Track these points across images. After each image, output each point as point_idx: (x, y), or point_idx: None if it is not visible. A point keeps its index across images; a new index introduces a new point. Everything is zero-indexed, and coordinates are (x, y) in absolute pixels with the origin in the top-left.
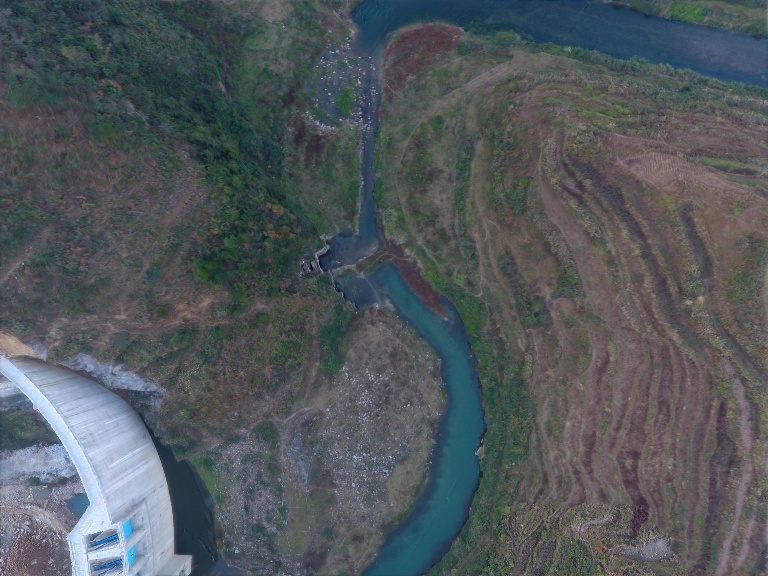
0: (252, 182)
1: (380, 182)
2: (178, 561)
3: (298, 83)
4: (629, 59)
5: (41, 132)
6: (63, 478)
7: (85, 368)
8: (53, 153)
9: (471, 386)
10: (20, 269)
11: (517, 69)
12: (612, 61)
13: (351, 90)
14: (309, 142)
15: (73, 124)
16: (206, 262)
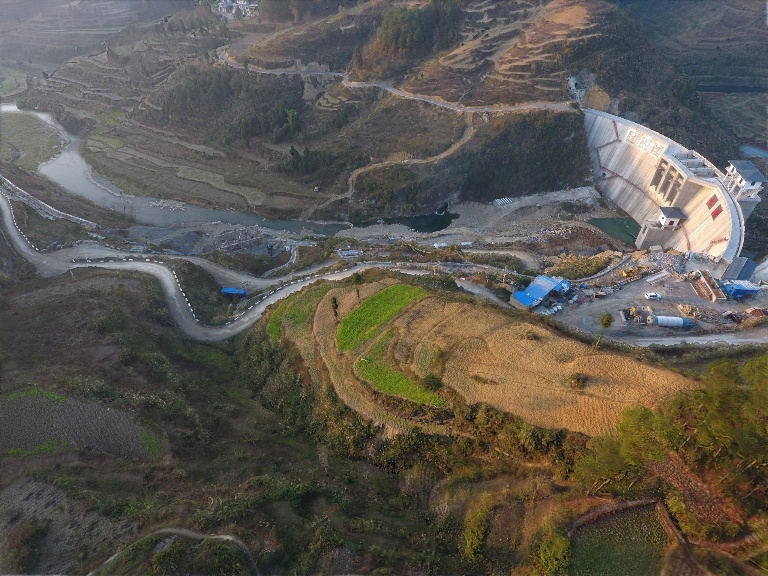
0: None
1: (723, 121)
2: None
3: None
4: None
5: None
6: (584, 207)
7: None
8: None
9: None
10: None
11: None
12: None
13: None
14: None
15: None
16: None
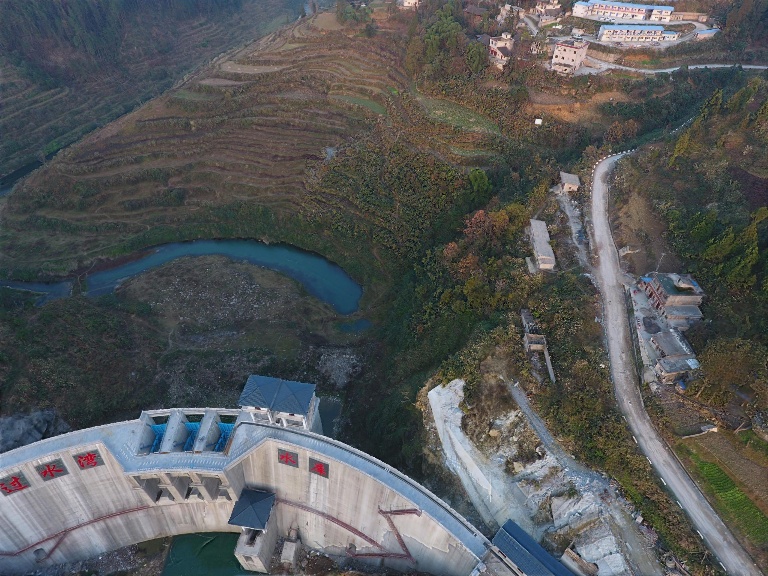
0: None
1: (16, 271)
2: None
3: None
4: None
5: None
6: None
7: None
8: None
9: (217, 244)
10: None
11: None
12: None
13: None
14: None
15: None
16: None
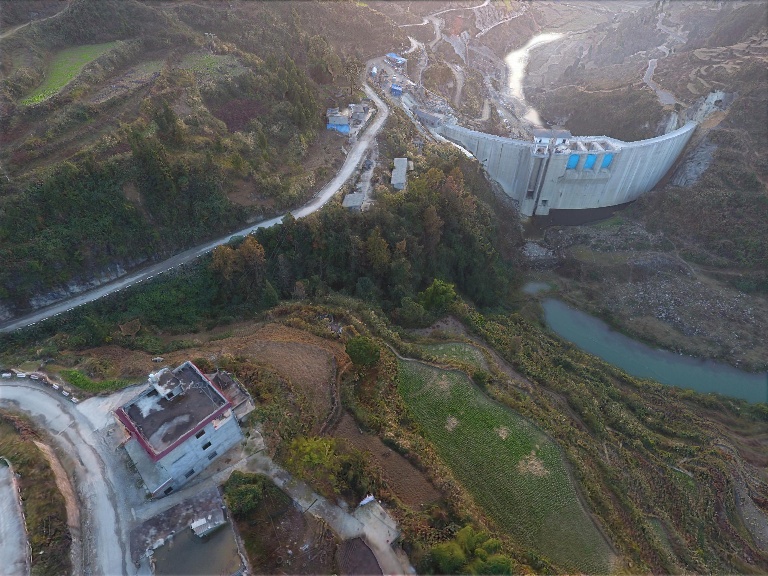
0: None
1: None
2: None
3: None
4: None
5: None
6: None
7: None
8: None
9: None
10: None
11: None
12: None
13: None
14: None
15: None
16: None
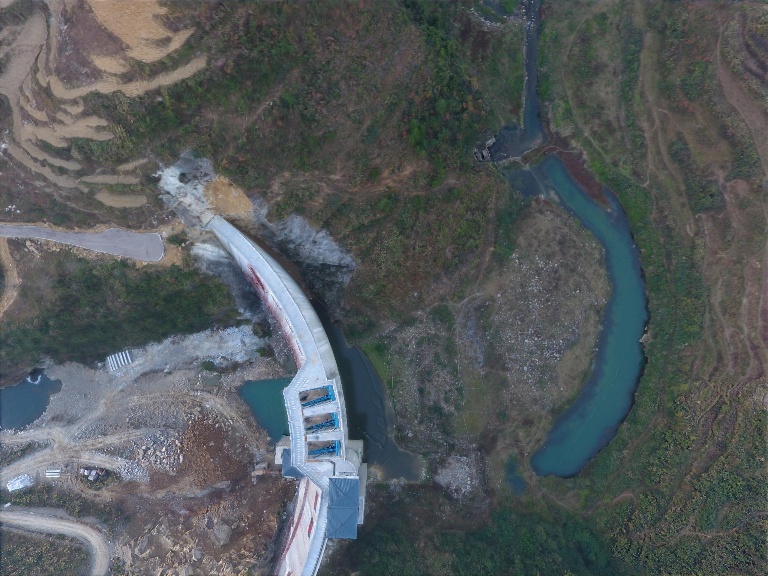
0: (456, 52)
1: (547, 75)
2: (354, 443)
3: None
4: None
5: None
6: (235, 363)
7: (290, 233)
8: None
9: (634, 276)
10: (269, 109)
11: None
12: None
13: None
14: (475, 37)
15: None
16: (421, 123)
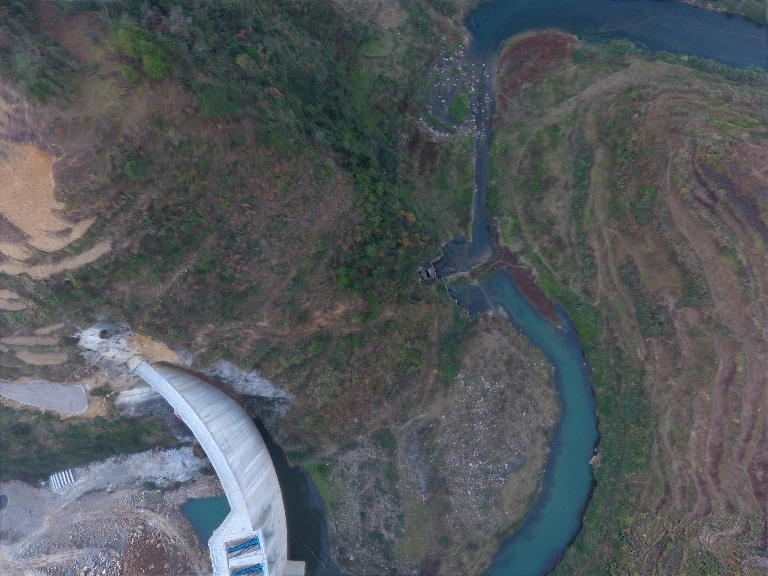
0: (390, 190)
1: (496, 189)
2: (294, 567)
3: (412, 90)
4: (746, 68)
5: (220, 140)
6: (177, 483)
7: (220, 374)
8: (226, 161)
9: (584, 394)
10: (183, 276)
11: (637, 78)
12: (729, 70)
13: (465, 97)
14: (423, 149)
15: (247, 132)
16: (349, 270)
